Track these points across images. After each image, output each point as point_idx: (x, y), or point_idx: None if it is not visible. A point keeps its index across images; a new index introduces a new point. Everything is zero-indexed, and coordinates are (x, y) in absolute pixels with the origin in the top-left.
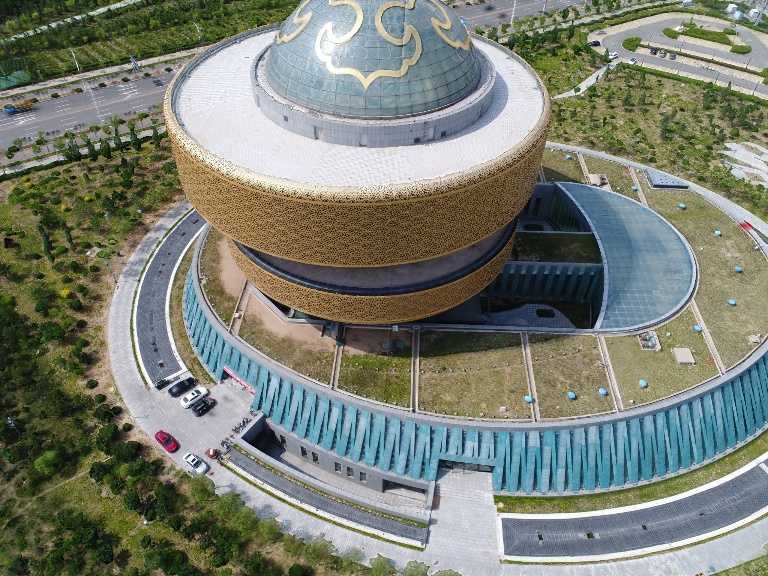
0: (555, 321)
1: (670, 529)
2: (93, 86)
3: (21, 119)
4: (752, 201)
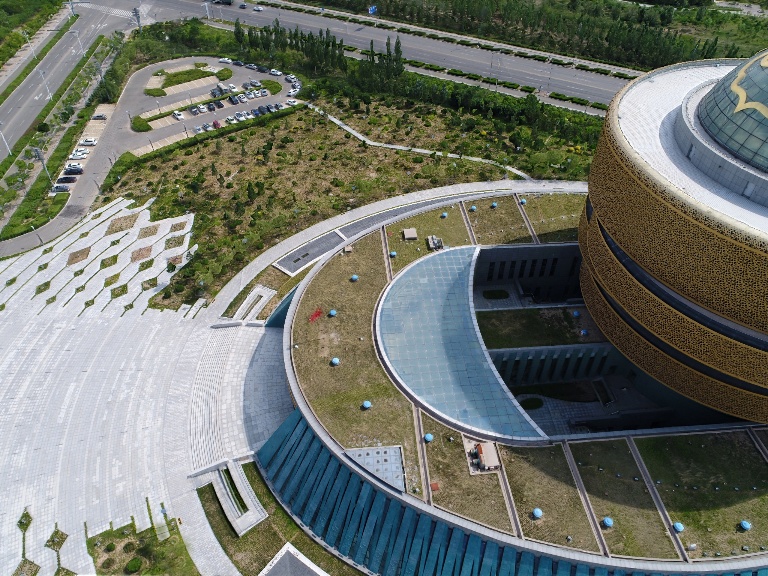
0: None
1: (417, 208)
2: None
3: None
4: None
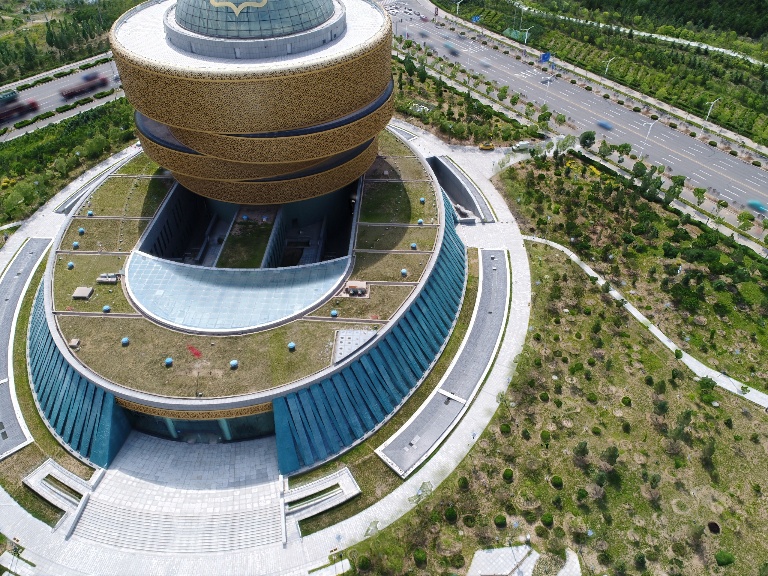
0: None
1: None
2: (528, 61)
3: None
4: (411, 547)
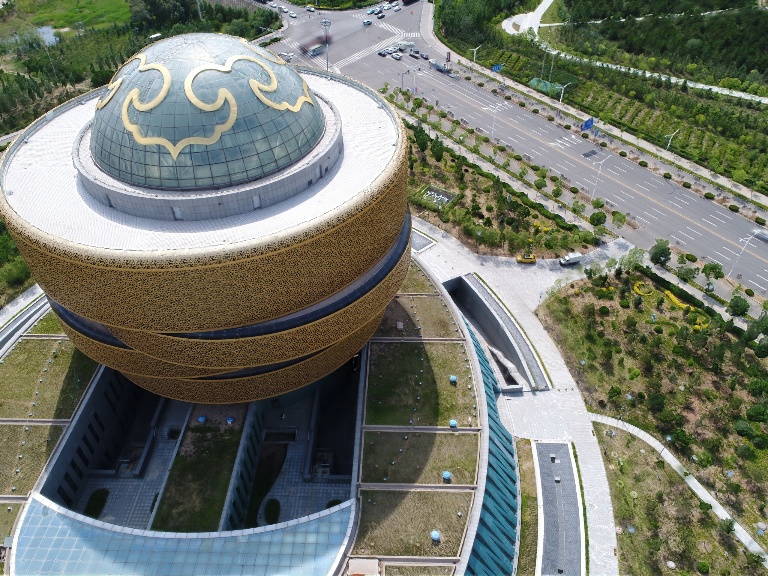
0: (144, 512)
1: None
2: (563, 123)
3: (491, 107)
4: None
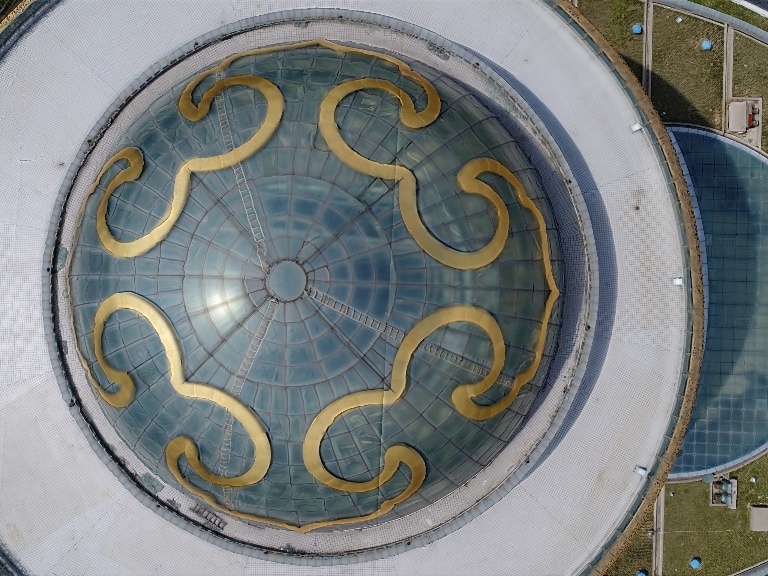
0: None
1: None
2: None
3: None
4: None
